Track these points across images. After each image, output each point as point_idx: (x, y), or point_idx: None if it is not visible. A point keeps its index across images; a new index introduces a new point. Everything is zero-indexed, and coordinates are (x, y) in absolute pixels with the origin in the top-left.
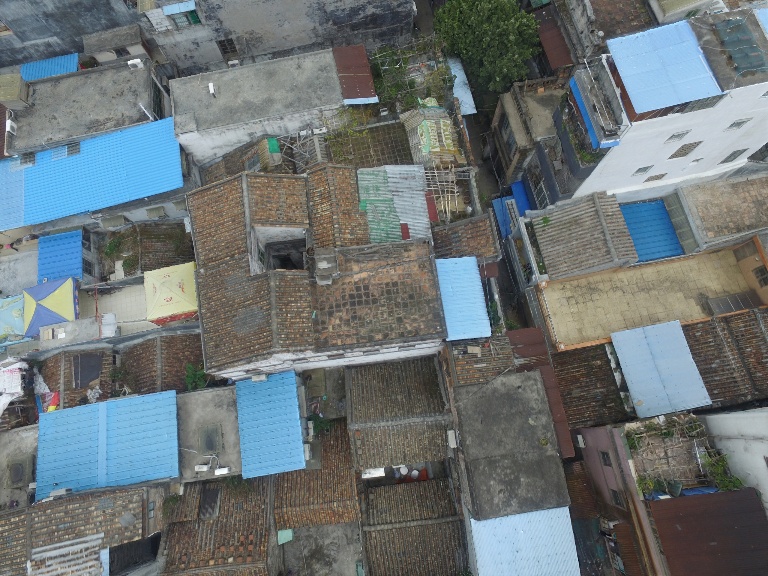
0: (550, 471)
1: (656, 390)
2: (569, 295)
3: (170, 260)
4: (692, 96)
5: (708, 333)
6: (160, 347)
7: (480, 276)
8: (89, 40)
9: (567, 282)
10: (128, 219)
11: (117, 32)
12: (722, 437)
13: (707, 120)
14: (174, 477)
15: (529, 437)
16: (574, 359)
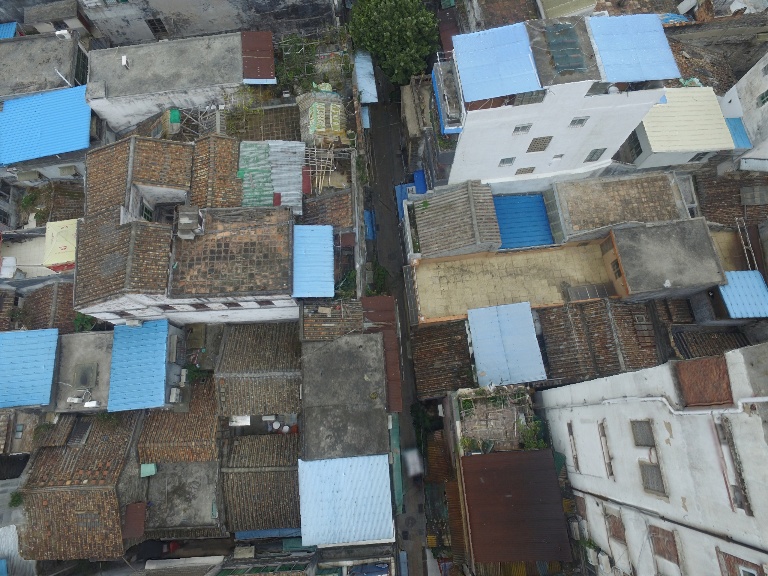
0: (375, 422)
1: (499, 363)
2: (442, 275)
3: (80, 216)
4: (515, 90)
5: (561, 317)
6: (56, 292)
7: (333, 243)
8: (30, 11)
9: (442, 263)
10: (44, 175)
11: (56, 6)
12: (548, 408)
13: (543, 115)
14: (45, 405)
15: (362, 391)
16: (440, 333)
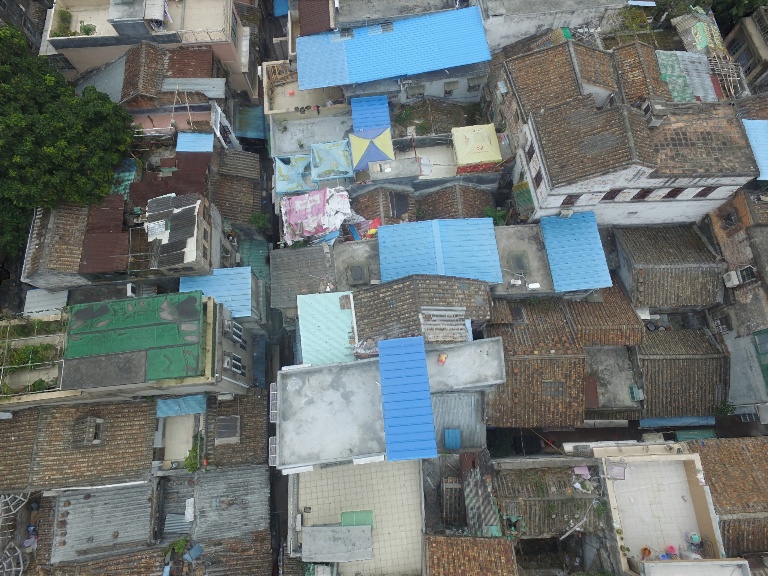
0: None
1: None
2: None
3: None
4: None
5: None
6: (459, 193)
7: None
8: None
9: None
10: None
11: None
12: None
13: None
14: None
15: None
16: None
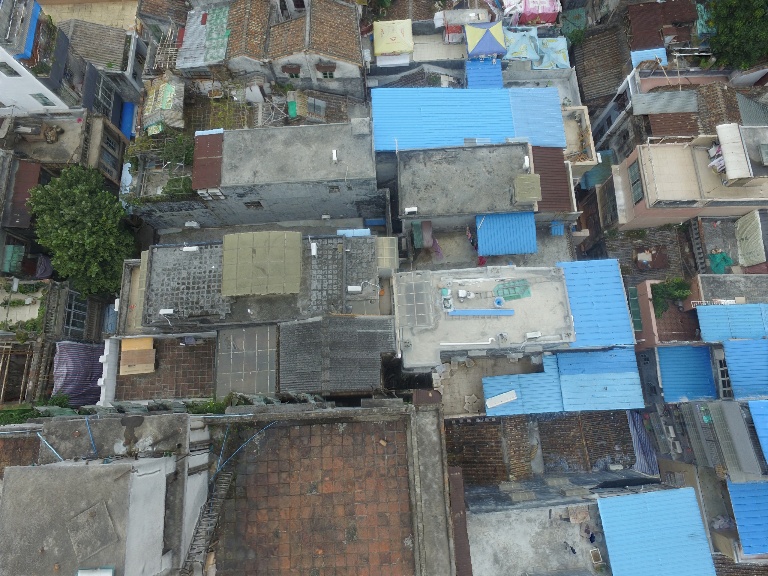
0: None
1: None
2: None
3: (406, 86)
4: None
5: None
6: None
7: None
8: None
9: None
10: None
11: None
12: None
13: None
14: None
15: None
16: None
